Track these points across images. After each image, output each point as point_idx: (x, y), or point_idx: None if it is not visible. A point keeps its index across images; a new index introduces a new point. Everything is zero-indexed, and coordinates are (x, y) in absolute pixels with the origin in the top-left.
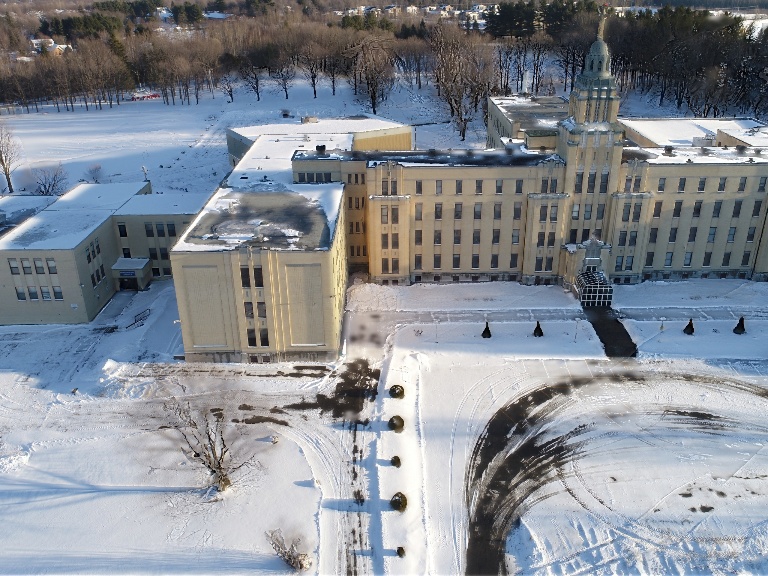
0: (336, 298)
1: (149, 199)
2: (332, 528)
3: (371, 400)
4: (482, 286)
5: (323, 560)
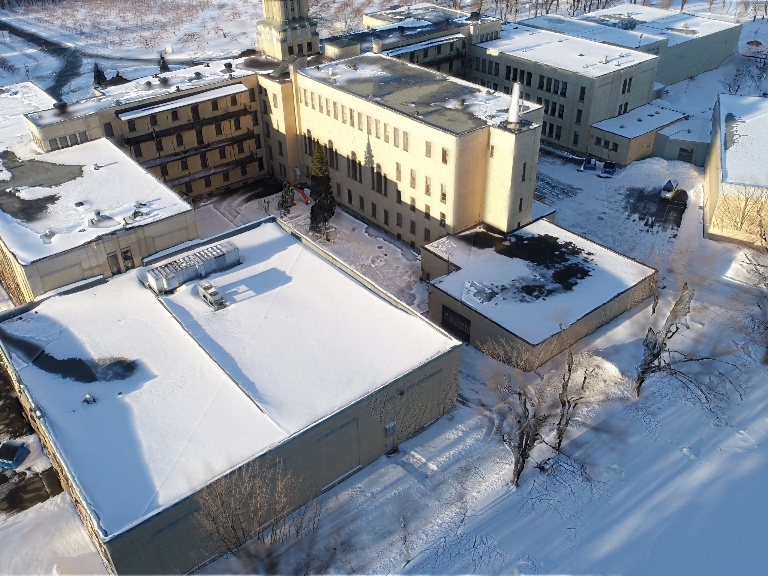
0: None
1: None
2: None
3: None
4: None
5: None
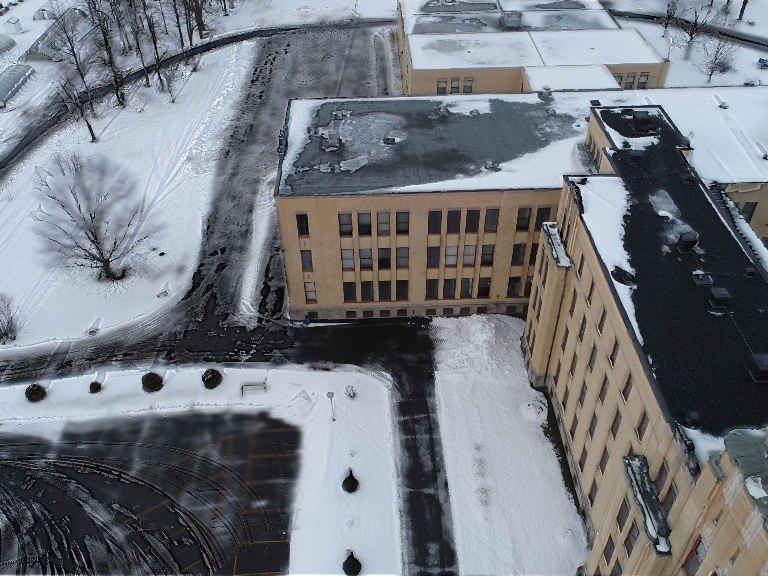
0: (324, 265)
1: (596, 75)
2: (36, 352)
3: (207, 358)
4: (548, 492)
5: (4, 351)
